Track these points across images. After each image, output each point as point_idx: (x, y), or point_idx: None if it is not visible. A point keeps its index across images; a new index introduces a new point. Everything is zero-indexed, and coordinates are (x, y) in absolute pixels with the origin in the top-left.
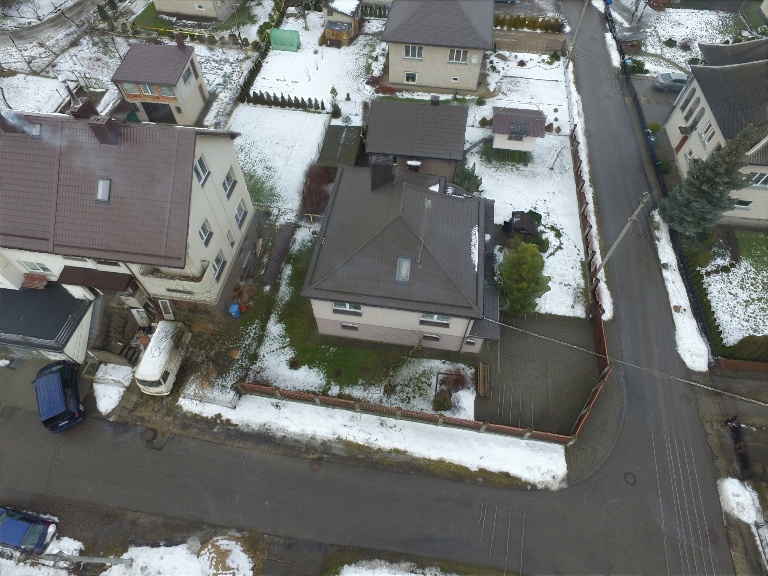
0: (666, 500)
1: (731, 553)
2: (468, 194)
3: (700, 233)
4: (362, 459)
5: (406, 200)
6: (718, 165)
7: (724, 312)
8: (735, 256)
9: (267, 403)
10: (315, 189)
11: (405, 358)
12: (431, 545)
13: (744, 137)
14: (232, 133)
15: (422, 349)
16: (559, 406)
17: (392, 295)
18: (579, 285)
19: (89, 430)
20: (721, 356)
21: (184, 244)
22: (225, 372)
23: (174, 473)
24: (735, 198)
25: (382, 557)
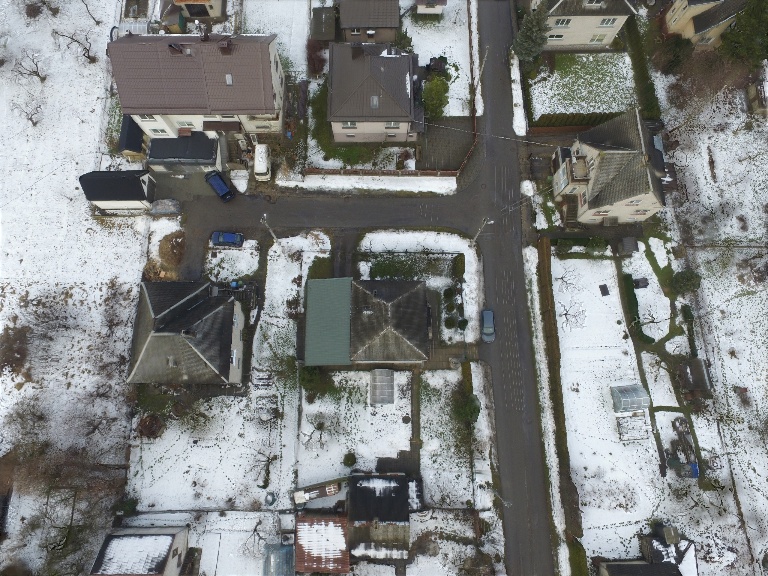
0: (498, 192)
1: (521, 208)
2: (403, 52)
3: (535, 58)
4: (367, 195)
5: (372, 65)
6: (533, 21)
7: (539, 104)
8: (551, 70)
9: (318, 177)
10: (315, 57)
11: (380, 148)
12: (400, 222)
13: (543, 4)
14: (275, 36)
15: (388, 143)
16: (454, 161)
17: (371, 115)
18: (467, 98)
19: (239, 200)
20: (533, 127)
21: (273, 102)
22: (293, 166)
23: (285, 211)
24: (546, 37)
25: (381, 229)
